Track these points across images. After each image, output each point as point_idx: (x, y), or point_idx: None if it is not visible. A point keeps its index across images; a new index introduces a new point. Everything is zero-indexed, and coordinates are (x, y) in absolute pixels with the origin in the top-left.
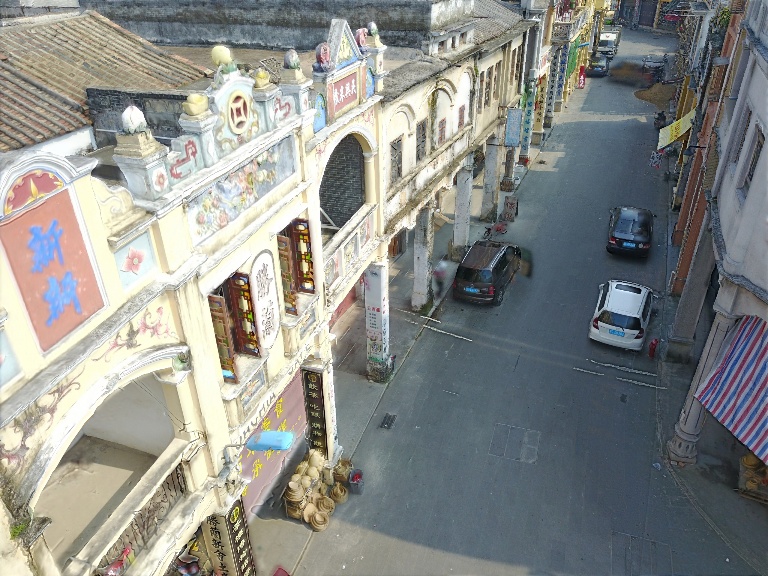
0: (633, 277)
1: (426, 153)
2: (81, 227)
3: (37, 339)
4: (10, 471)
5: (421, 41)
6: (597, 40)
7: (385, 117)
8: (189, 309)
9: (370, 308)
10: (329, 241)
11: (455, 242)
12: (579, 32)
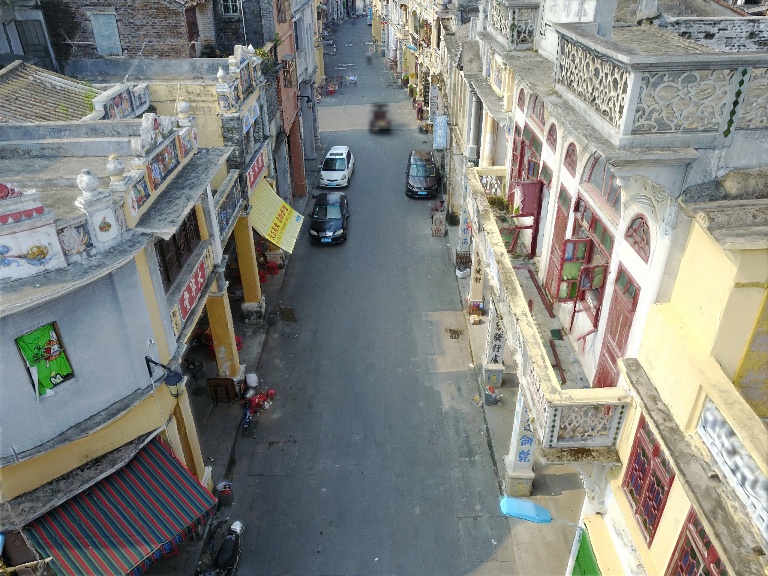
0: None
1: None
2: None
3: None
4: None
5: None
6: None
7: None
8: None
9: None
10: None
11: None
12: None
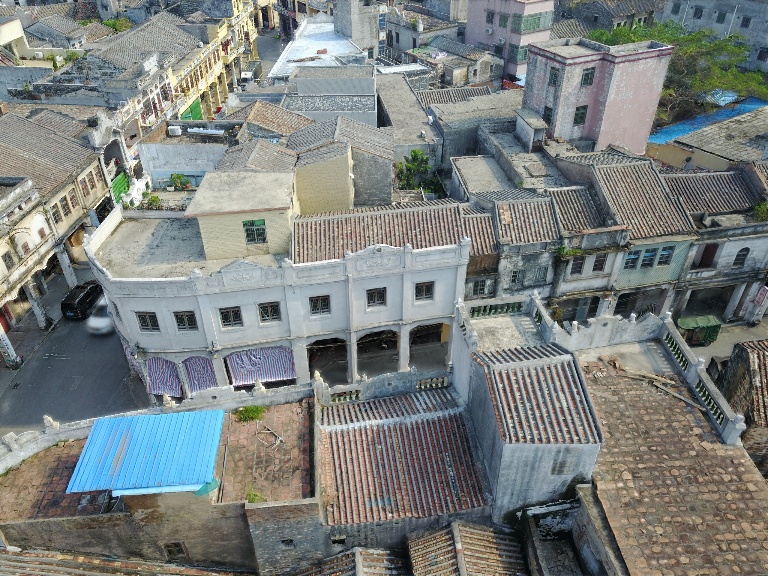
0: None
1: (15, 263)
2: None
3: None
4: None
5: None
6: None
7: None
8: None
9: None
10: None
11: (69, 286)
12: (194, 99)
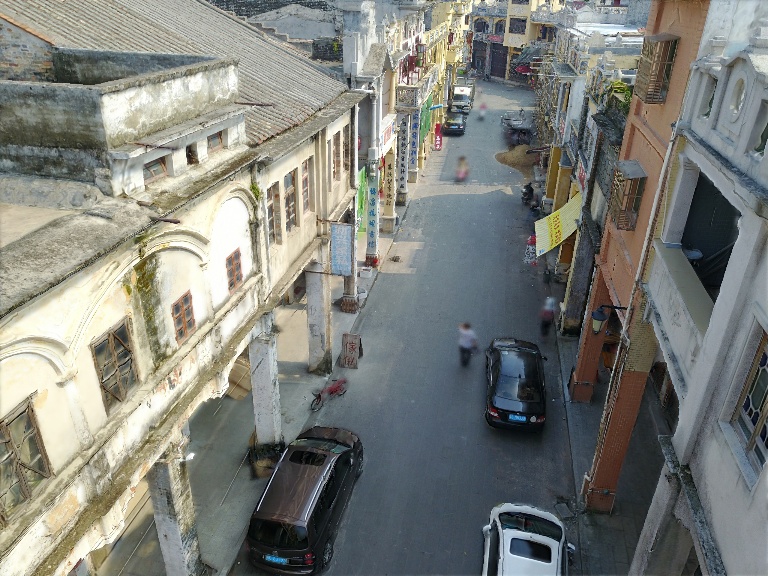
0: (527, 472)
1: (140, 376)
2: None
3: None
4: None
5: (93, 168)
6: (451, 94)
7: None
8: None
9: None
10: None
11: (259, 440)
12: None
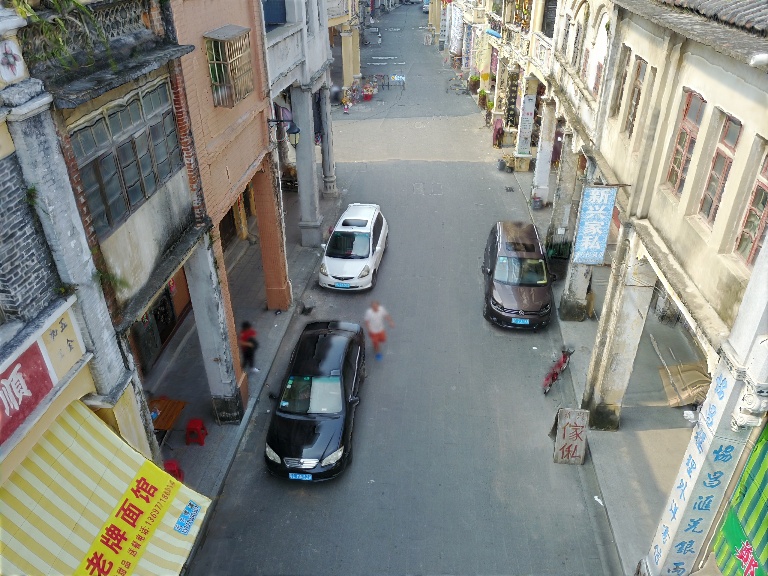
0: None
1: None
2: None
3: None
4: None
5: None
6: None
7: None
8: None
9: None
10: None
11: None
12: None
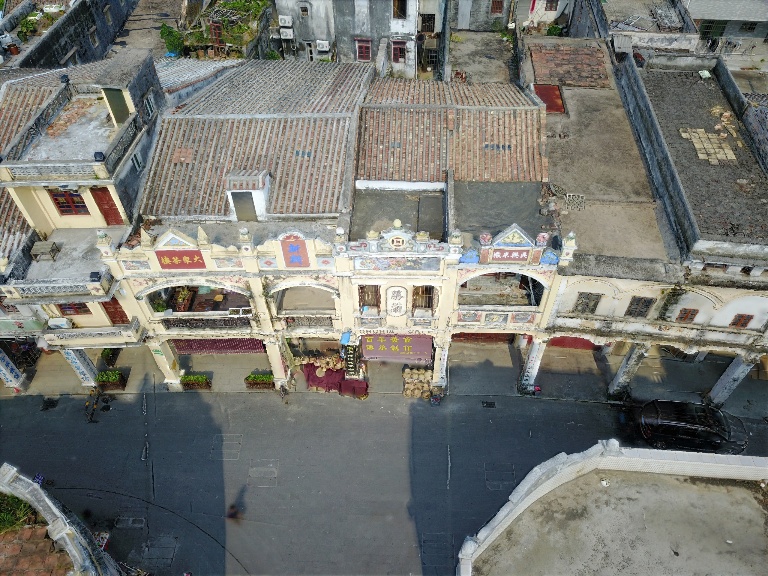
0: None
1: (647, 316)
2: (307, 248)
3: (285, 264)
4: (269, 283)
5: (684, 253)
6: None
7: (572, 278)
8: (343, 283)
9: (528, 354)
10: (480, 305)
11: (711, 392)
12: None
